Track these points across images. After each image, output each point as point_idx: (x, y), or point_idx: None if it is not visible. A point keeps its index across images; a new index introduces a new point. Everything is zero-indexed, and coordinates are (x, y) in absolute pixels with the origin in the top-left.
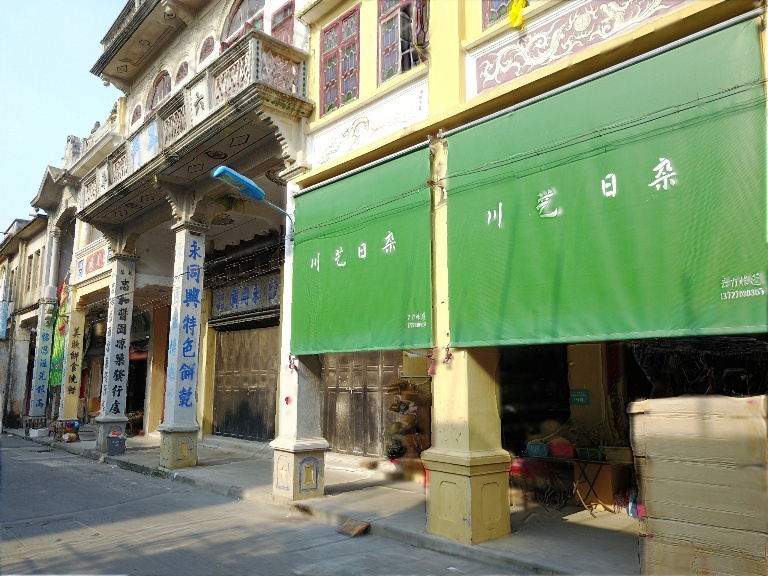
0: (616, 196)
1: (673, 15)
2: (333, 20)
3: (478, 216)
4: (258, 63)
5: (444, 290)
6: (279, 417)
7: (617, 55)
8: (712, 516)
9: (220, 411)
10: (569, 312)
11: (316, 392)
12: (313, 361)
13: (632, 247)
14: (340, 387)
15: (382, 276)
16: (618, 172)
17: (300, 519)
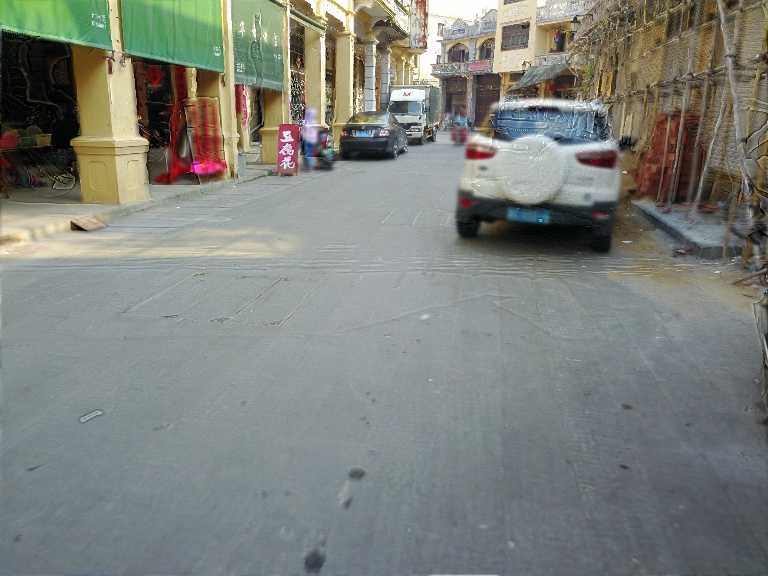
0: None
1: None
2: None
3: None
4: None
5: None
6: None
7: None
8: None
9: None
10: None
11: None
12: None
13: None
14: None
15: None
16: None
17: (26, 247)
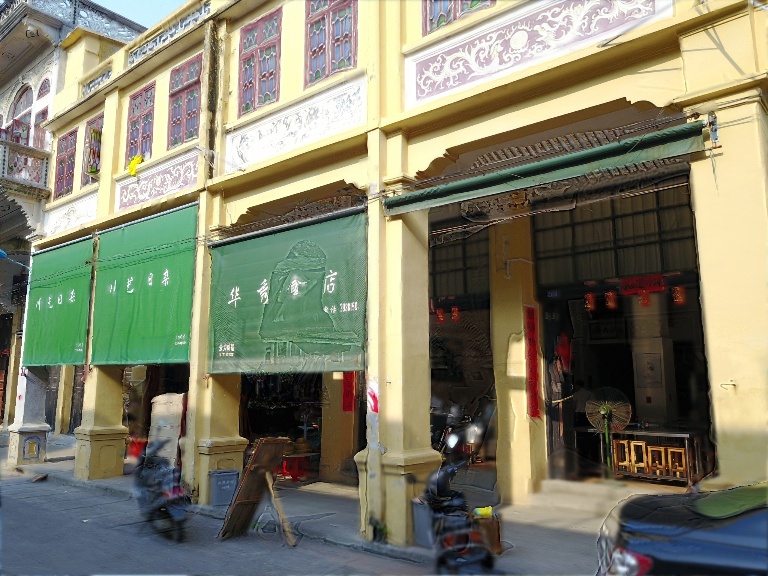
0: (151, 286)
1: (173, 195)
2: (64, 134)
3: (107, 287)
4: (4, 163)
5: None
6: None
7: (156, 209)
8: (163, 453)
9: None
10: (132, 347)
11: (42, 392)
12: (40, 370)
13: (154, 315)
14: None
15: (68, 317)
16: (153, 273)
17: (14, 476)
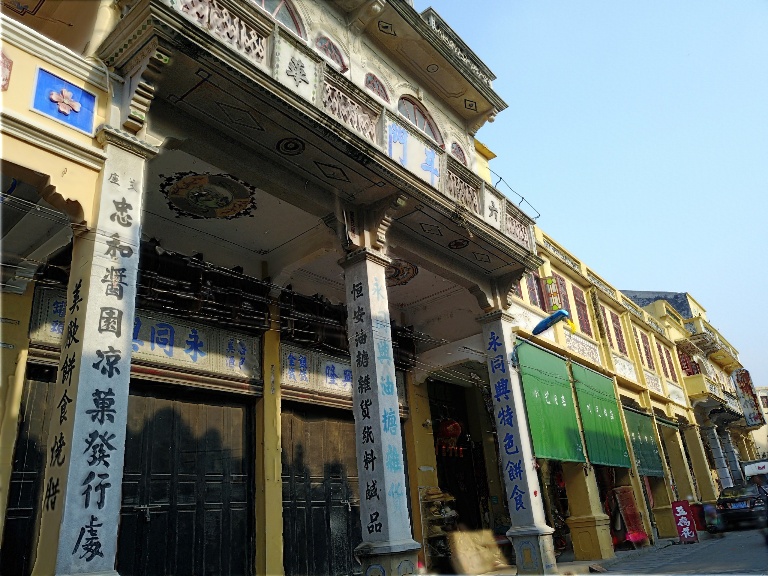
0: None
1: (606, 368)
2: None
3: None
4: None
5: None
6: None
7: (601, 371)
8: None
9: (17, 570)
10: None
11: None
12: None
13: None
14: (333, 500)
15: (564, 418)
16: None
17: None
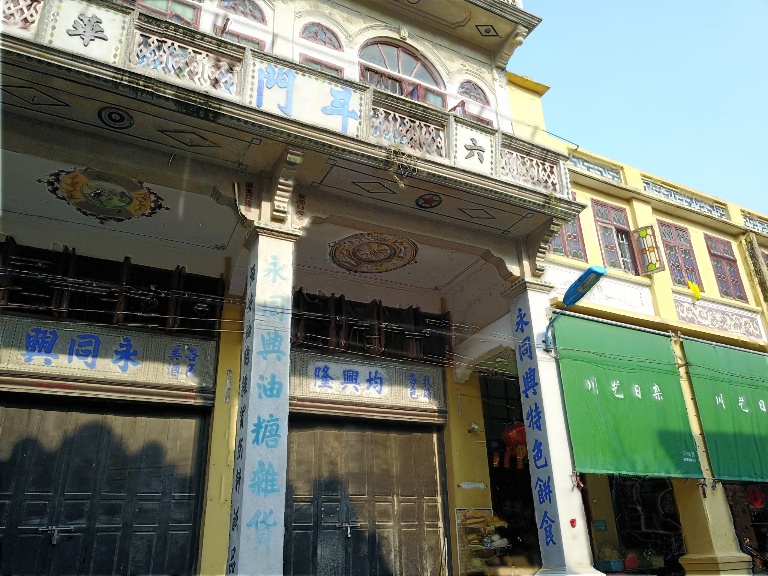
0: (767, 412)
1: None
2: None
3: (712, 397)
4: None
5: (698, 438)
6: (565, 543)
7: (755, 347)
8: None
9: None
10: (766, 466)
11: None
12: None
13: None
14: (324, 523)
15: (657, 416)
16: (764, 401)
17: None
